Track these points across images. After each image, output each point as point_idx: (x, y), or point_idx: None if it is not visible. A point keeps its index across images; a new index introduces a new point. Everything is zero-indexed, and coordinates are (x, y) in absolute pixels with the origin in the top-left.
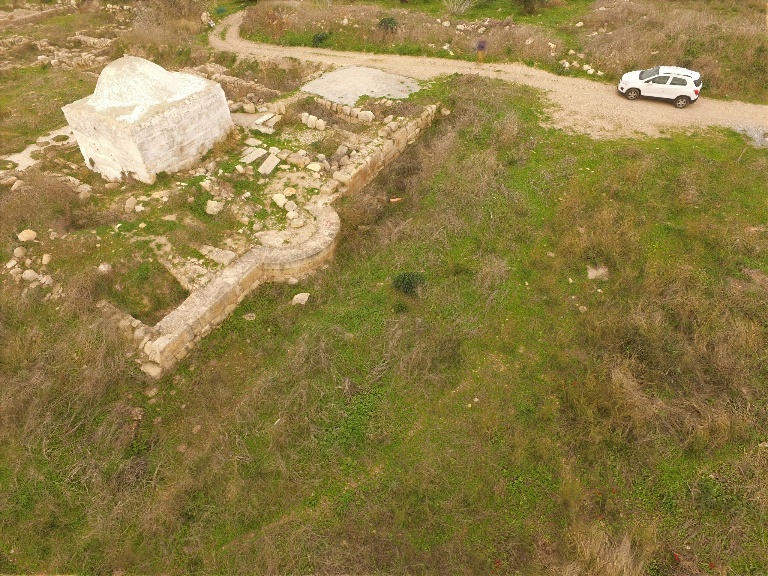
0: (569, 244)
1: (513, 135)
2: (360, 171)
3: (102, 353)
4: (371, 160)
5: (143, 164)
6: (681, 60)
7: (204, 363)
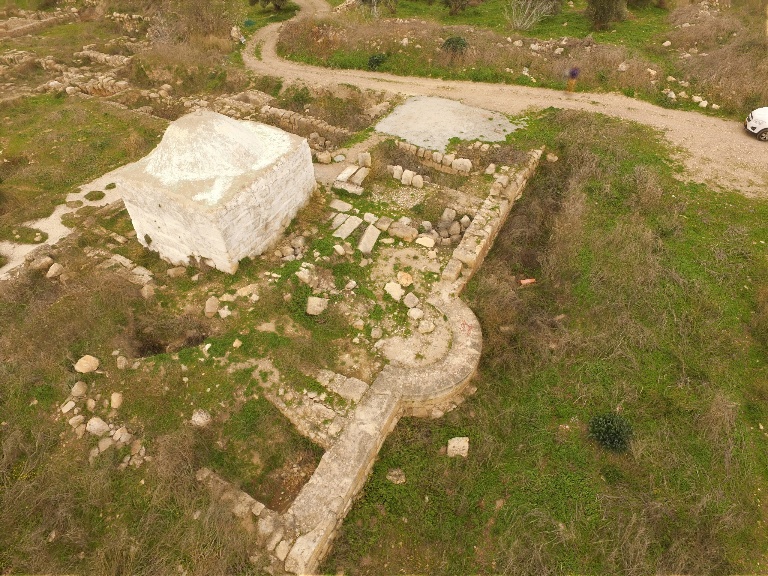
0: None
1: (658, 196)
2: (483, 246)
3: (223, 570)
4: (492, 230)
5: (226, 253)
6: None
7: (355, 563)
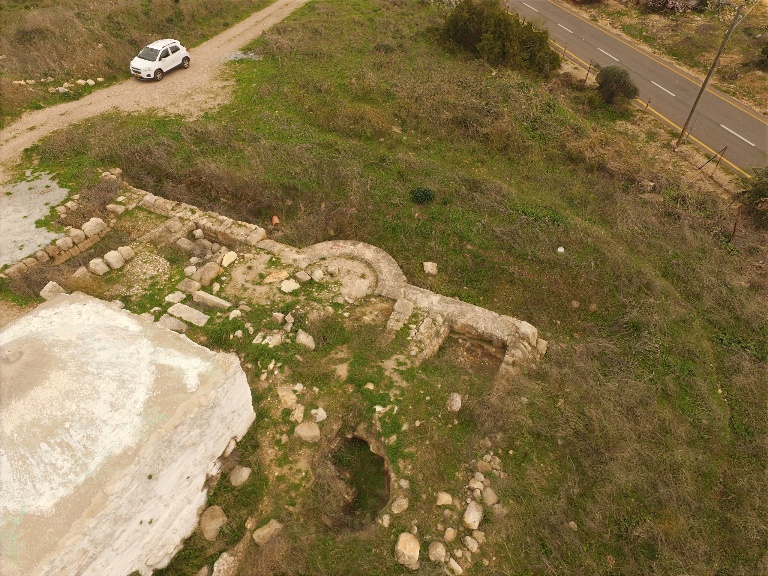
0: (379, 128)
1: (220, 128)
2: None
3: None
4: None
5: (250, 397)
6: (123, 42)
7: None
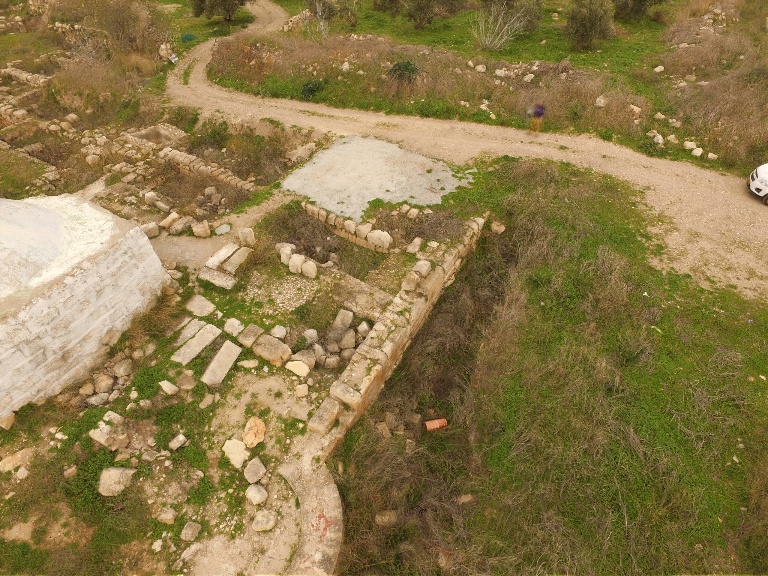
0: None
1: (623, 299)
2: (375, 376)
3: None
4: (393, 348)
5: None
6: None
7: None
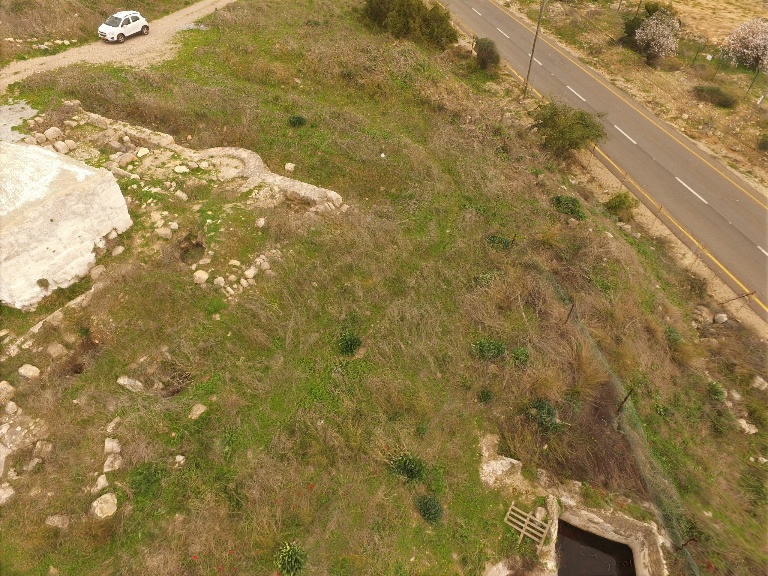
0: (281, 78)
1: (158, 74)
2: None
3: None
4: None
5: (125, 205)
6: None
7: None
